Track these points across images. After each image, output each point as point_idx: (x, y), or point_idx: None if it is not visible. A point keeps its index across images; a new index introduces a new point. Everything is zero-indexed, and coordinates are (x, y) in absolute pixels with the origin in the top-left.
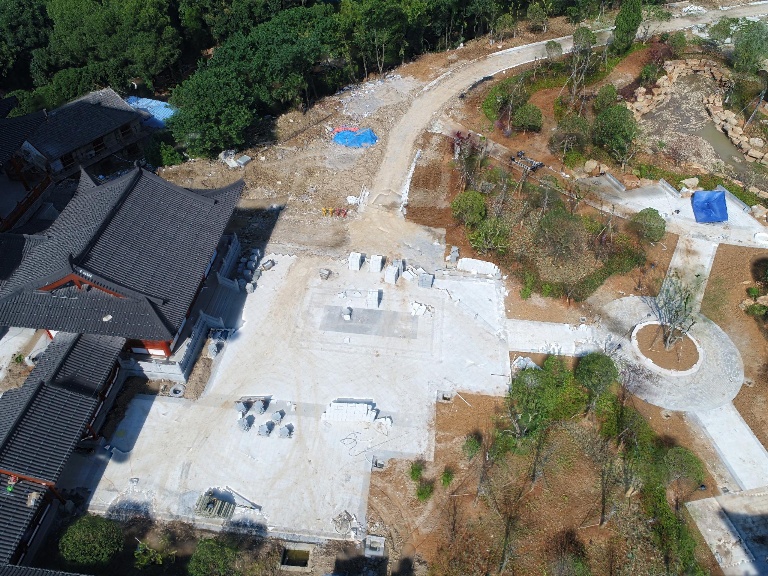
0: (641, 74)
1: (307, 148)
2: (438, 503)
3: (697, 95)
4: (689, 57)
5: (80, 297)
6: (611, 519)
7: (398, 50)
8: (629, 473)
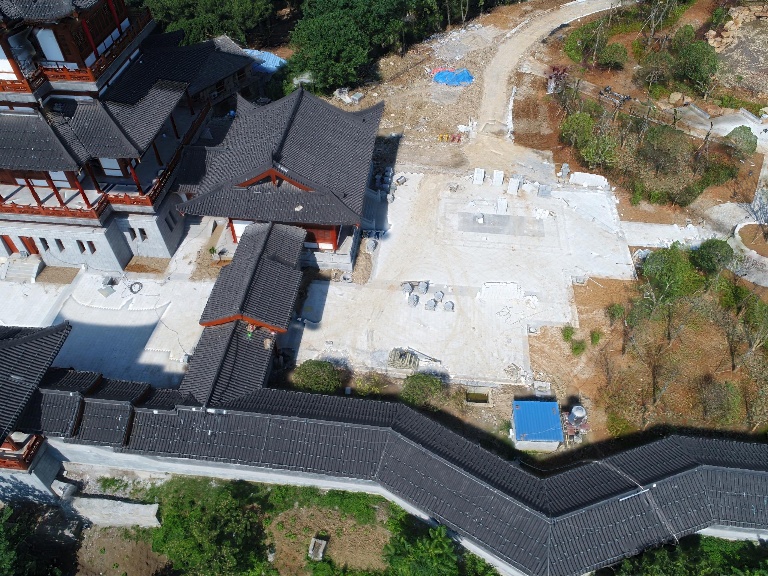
0: (709, 19)
1: (412, 86)
2: (590, 357)
3: (762, 38)
4: (751, 4)
5: (272, 192)
6: (741, 366)
7: (473, 3)
8: (750, 334)
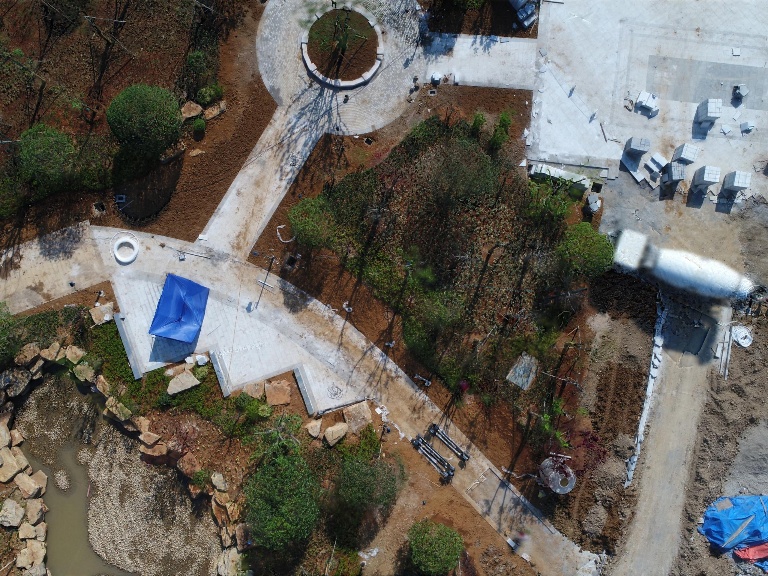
0: None
1: None
2: None
3: None
4: None
5: None
6: None
7: None
8: None
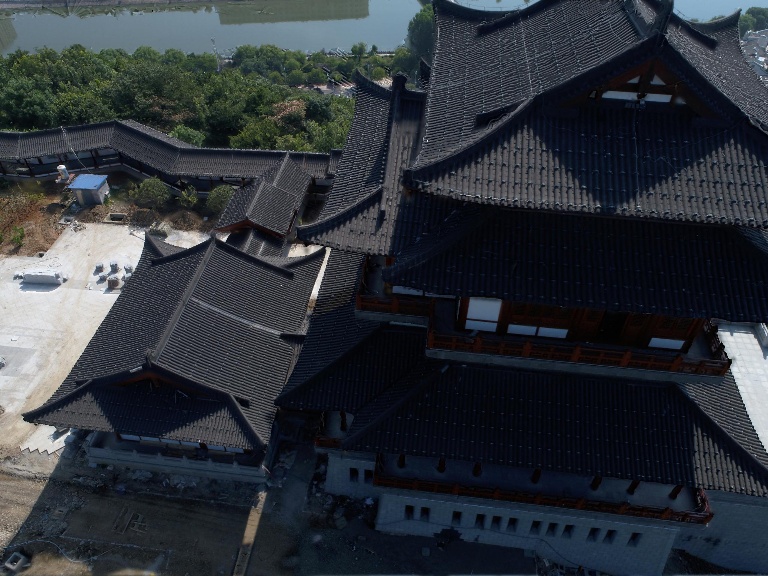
0: None
1: None
2: (14, 233)
3: None
4: None
5: None
6: None
7: None
8: None
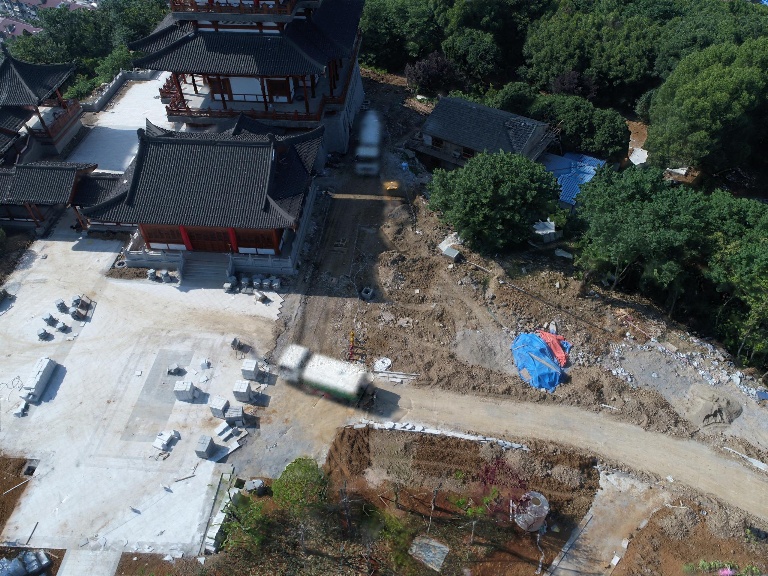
0: None
1: (494, 308)
2: None
3: None
4: None
5: None
6: None
7: None
8: None
